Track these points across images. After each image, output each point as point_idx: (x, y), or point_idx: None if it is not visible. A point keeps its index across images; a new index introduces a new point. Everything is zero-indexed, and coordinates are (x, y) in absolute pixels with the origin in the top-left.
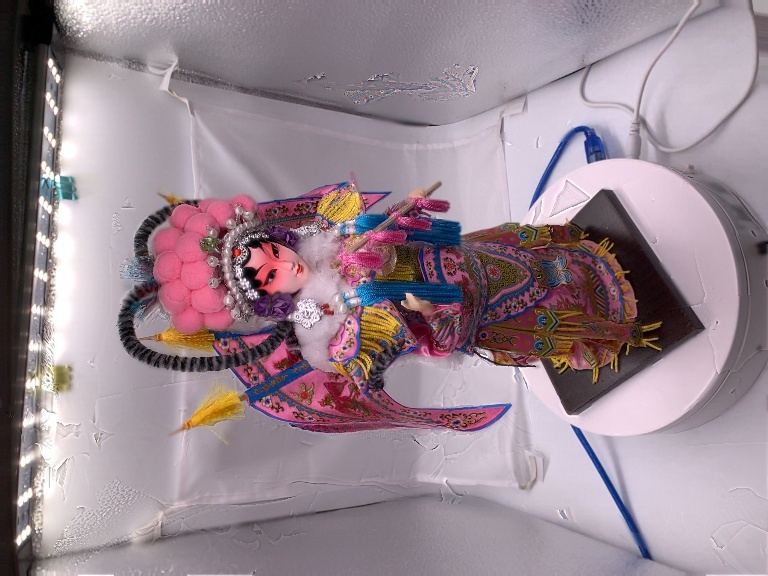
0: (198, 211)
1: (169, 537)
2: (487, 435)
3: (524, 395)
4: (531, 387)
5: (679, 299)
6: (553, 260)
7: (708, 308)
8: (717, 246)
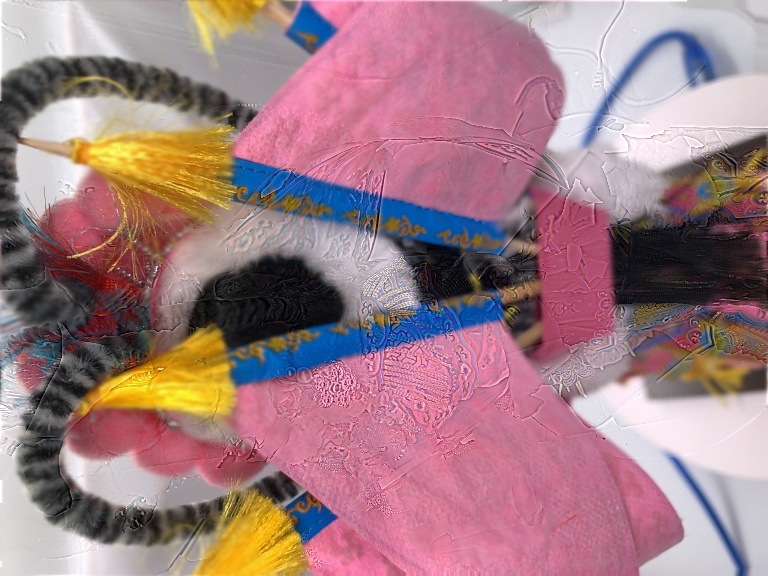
0: (157, 435)
1: (1, 27)
2: (429, 146)
3: (506, 118)
4: (488, 216)
5: (615, 410)
6: (584, 361)
7: (615, 432)
8: (683, 444)
